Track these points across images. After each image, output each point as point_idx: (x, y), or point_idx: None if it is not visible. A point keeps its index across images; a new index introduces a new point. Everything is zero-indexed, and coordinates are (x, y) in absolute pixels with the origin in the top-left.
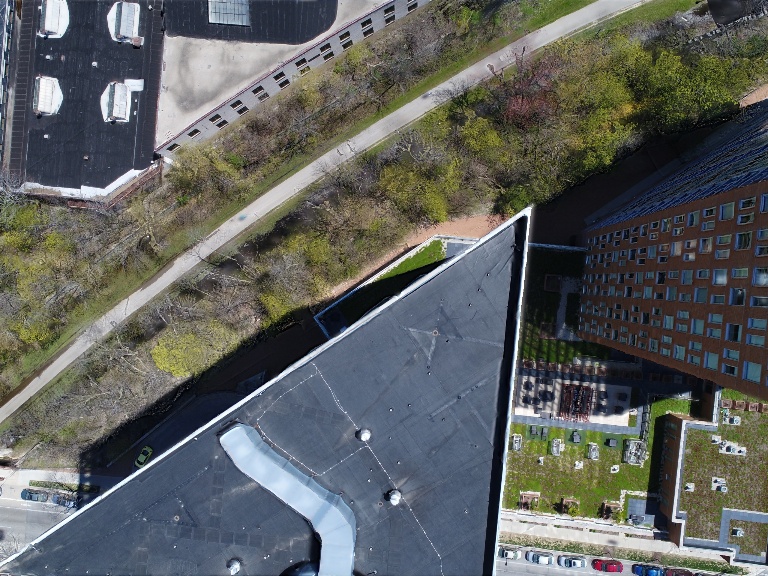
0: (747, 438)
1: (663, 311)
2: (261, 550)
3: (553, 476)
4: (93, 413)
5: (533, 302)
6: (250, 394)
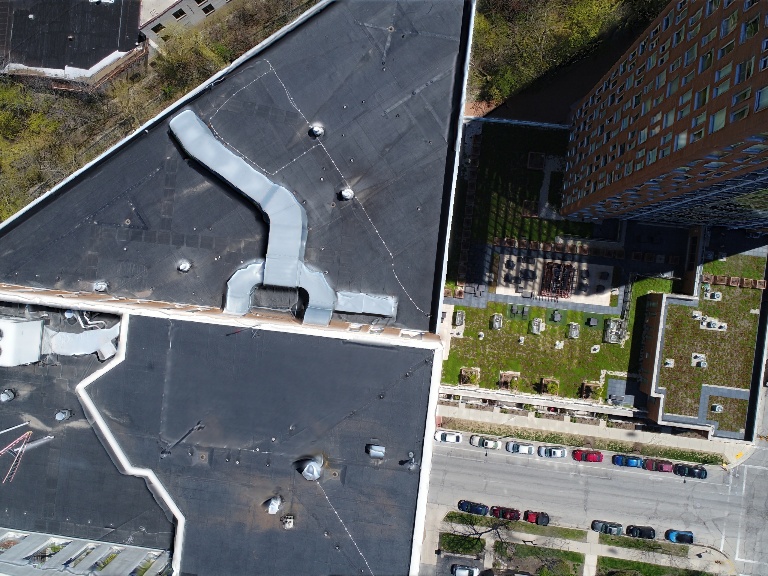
0: (728, 314)
1: (638, 128)
2: (212, 252)
3: (533, 356)
4: None
5: (516, 180)
6: (202, 84)
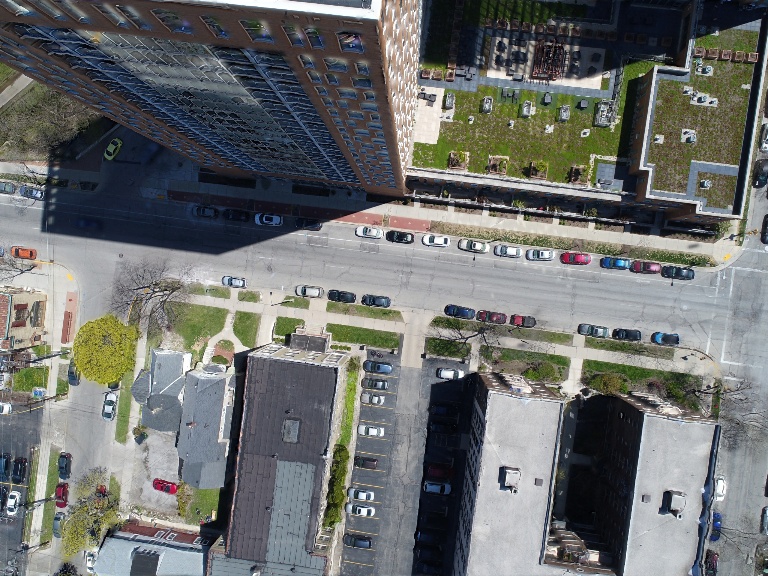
0: (719, 89)
1: None
2: None
3: (523, 140)
4: (65, 118)
5: None
6: None
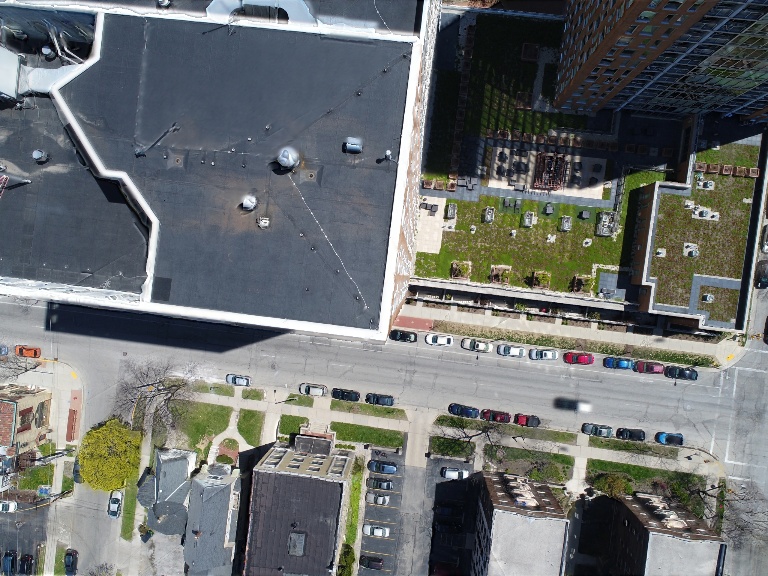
0: (720, 203)
1: None
2: None
3: (525, 249)
4: None
5: (510, 72)
6: None
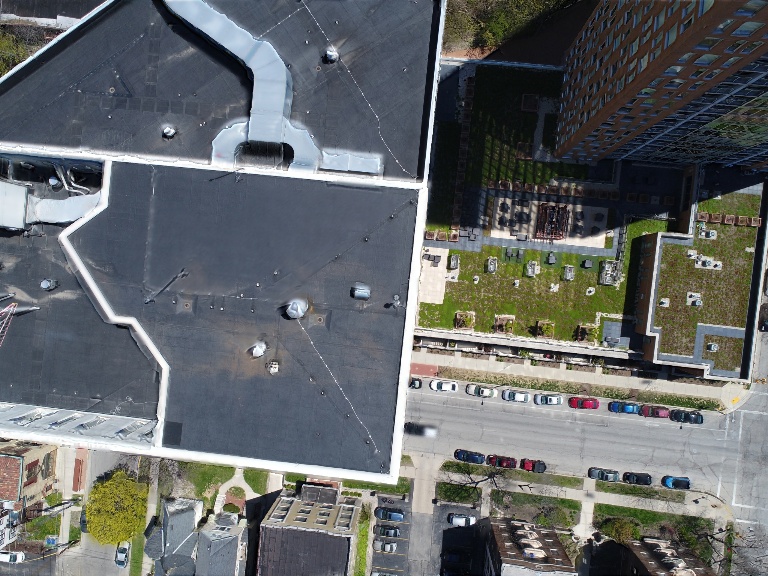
0: (723, 252)
1: (630, 41)
2: (197, 118)
3: (528, 299)
4: None
5: (510, 123)
6: None
